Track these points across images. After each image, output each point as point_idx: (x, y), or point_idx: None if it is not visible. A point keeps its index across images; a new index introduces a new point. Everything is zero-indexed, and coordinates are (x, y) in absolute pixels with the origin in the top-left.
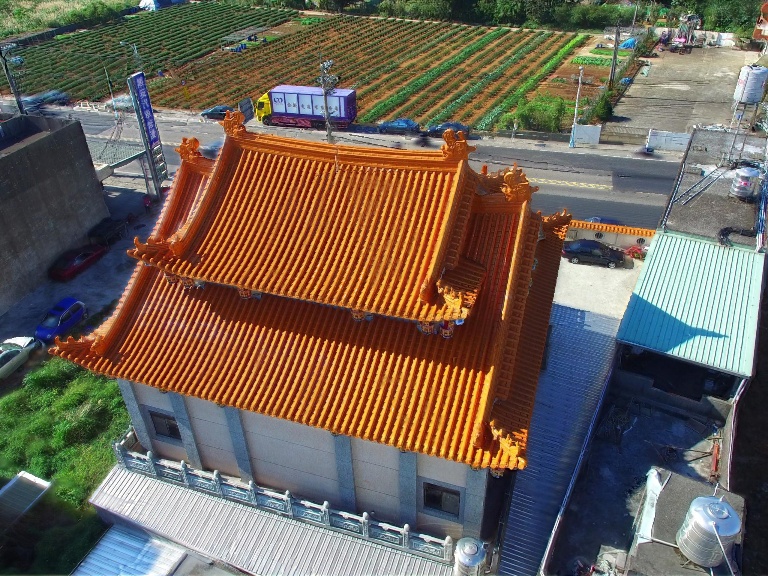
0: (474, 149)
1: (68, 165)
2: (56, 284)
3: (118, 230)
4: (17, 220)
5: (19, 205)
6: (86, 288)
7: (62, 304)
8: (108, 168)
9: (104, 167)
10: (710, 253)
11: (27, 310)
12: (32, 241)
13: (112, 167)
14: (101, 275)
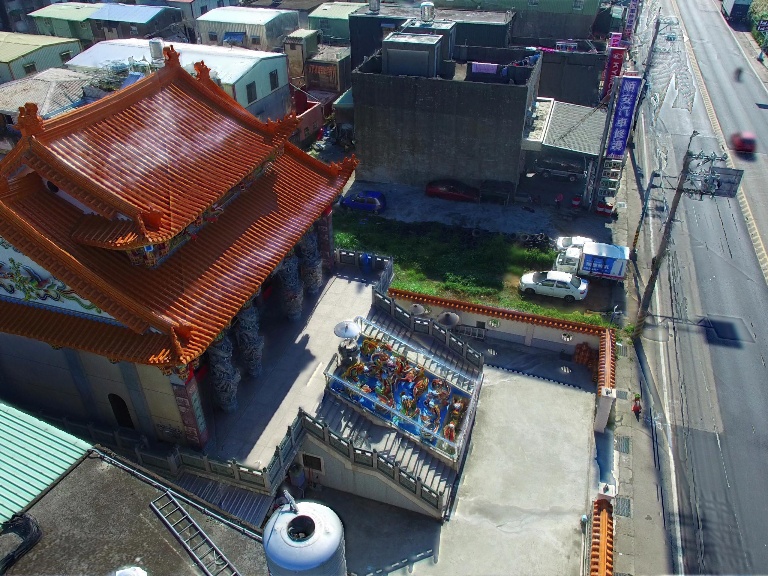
0: (15, 127)
1: (495, 117)
2: (424, 192)
3: (498, 194)
4: (427, 130)
5: (434, 121)
6: (419, 205)
7: (372, 193)
8: (539, 144)
9: (535, 141)
10: (5, 500)
11: (389, 190)
12: (431, 152)
13: (547, 146)
14: (439, 208)
